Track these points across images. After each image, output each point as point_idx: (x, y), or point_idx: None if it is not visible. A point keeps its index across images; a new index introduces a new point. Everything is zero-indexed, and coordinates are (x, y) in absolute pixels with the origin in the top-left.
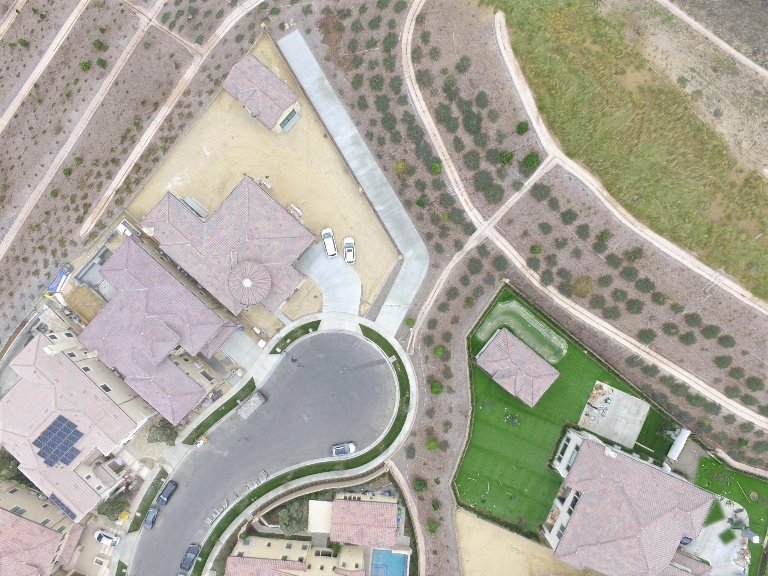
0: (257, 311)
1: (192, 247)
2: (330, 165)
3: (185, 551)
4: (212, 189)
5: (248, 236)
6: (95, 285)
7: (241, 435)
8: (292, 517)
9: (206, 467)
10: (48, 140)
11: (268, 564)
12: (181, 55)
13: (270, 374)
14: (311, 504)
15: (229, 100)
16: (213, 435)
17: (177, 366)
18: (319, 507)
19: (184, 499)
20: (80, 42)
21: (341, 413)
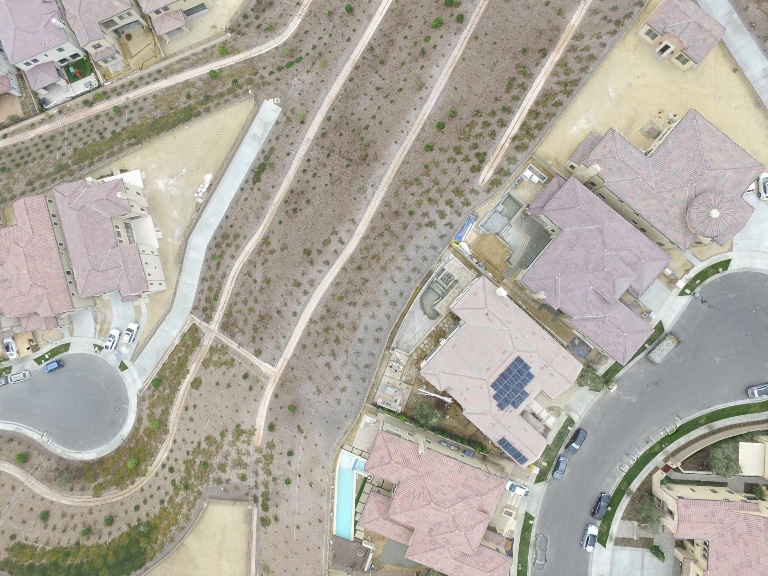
0: (667, 252)
1: (643, 182)
2: (740, 100)
3: (594, 501)
4: (618, 130)
5: (706, 167)
6: (495, 233)
7: (650, 380)
8: (730, 459)
9: (614, 414)
10: (409, 97)
11: (721, 506)
12: (561, 1)
13: (678, 317)
14: (741, 446)
15: (634, 39)
16: (620, 381)
17: (624, 305)
18: (750, 449)
19: (592, 447)
20: (416, 2)
21: (755, 354)
